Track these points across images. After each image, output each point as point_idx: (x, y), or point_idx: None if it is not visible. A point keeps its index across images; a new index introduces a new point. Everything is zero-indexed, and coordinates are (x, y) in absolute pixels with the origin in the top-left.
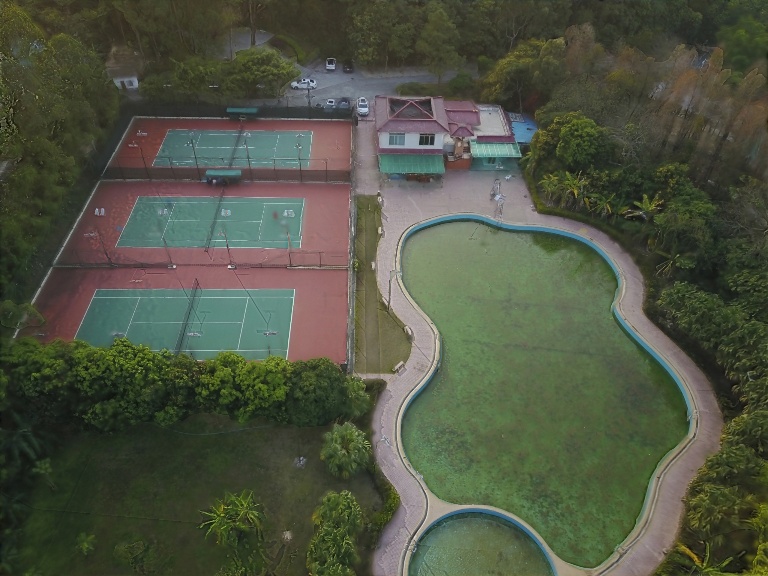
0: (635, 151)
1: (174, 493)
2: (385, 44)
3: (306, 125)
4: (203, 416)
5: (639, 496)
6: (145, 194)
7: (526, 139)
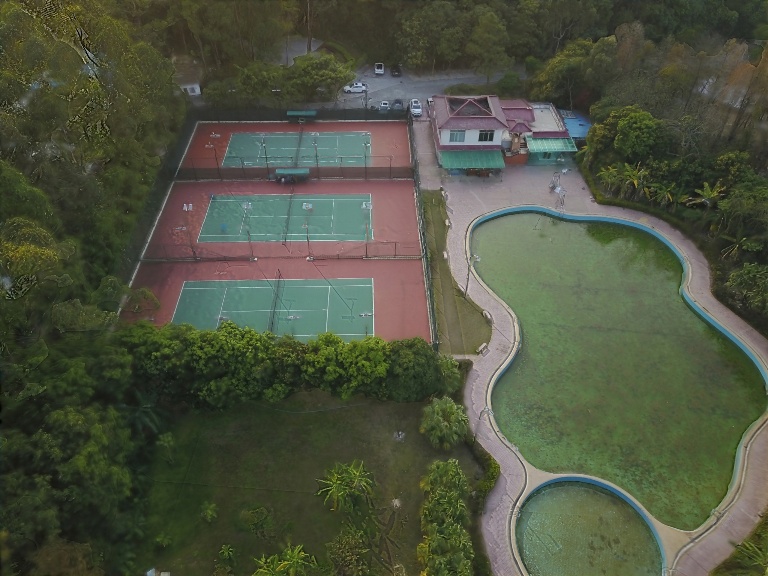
0: (694, 141)
1: (284, 466)
2: (433, 48)
3: (363, 126)
4: (302, 395)
5: (728, 465)
6: (218, 193)
7: (580, 134)
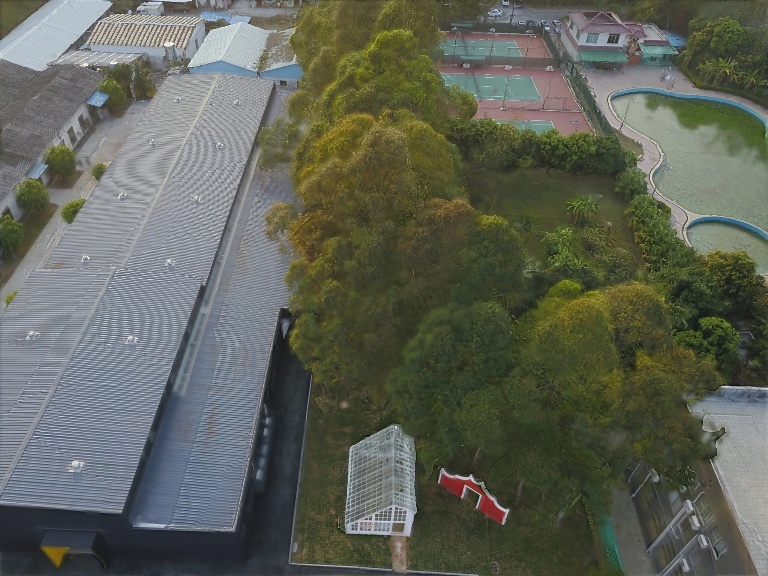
0: None
1: (531, 206)
2: None
3: (508, 37)
4: (528, 175)
5: None
6: None
7: (678, 44)
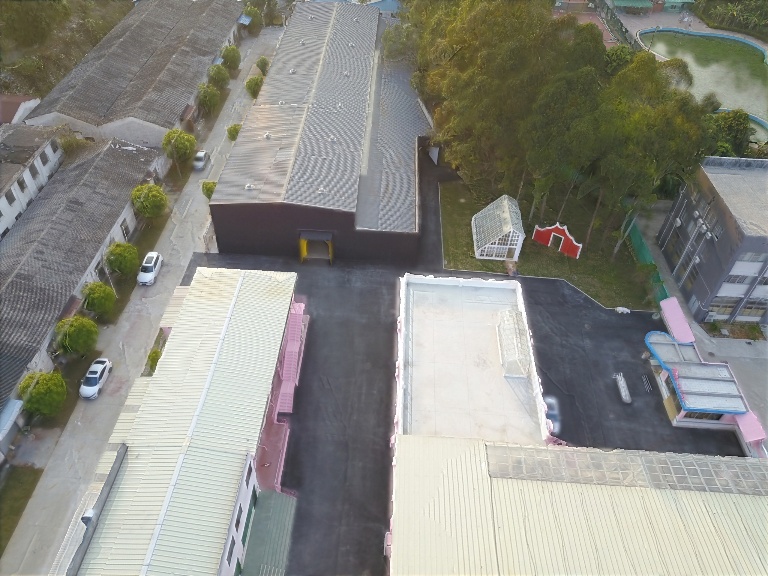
0: None
1: None
2: None
3: None
4: None
5: None
6: None
7: None
